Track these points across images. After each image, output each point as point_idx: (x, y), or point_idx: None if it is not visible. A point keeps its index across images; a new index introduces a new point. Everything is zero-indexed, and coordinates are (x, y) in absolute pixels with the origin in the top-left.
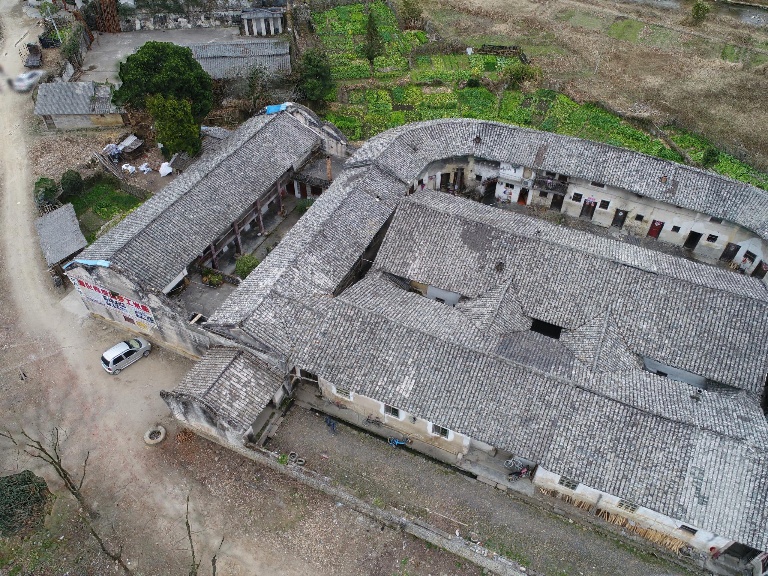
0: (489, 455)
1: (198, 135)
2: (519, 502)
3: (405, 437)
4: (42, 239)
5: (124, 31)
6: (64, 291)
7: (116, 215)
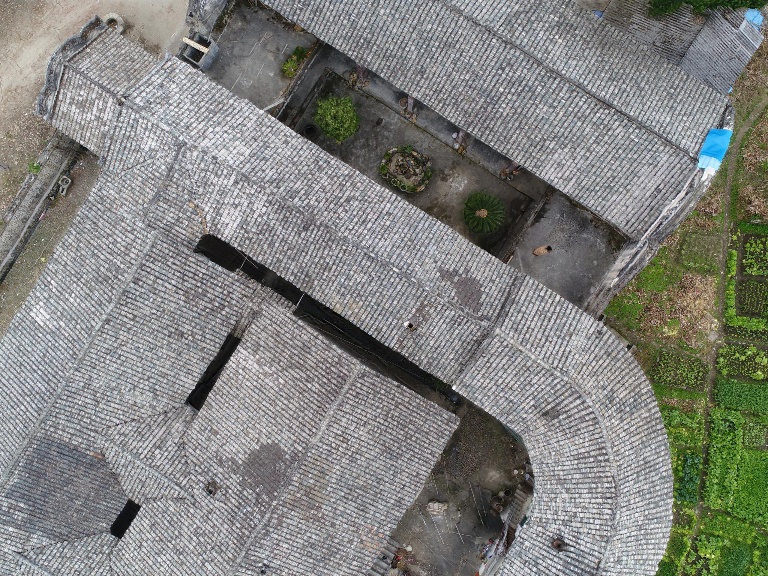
0: None
1: None
2: None
3: None
4: None
5: None
6: None
7: None
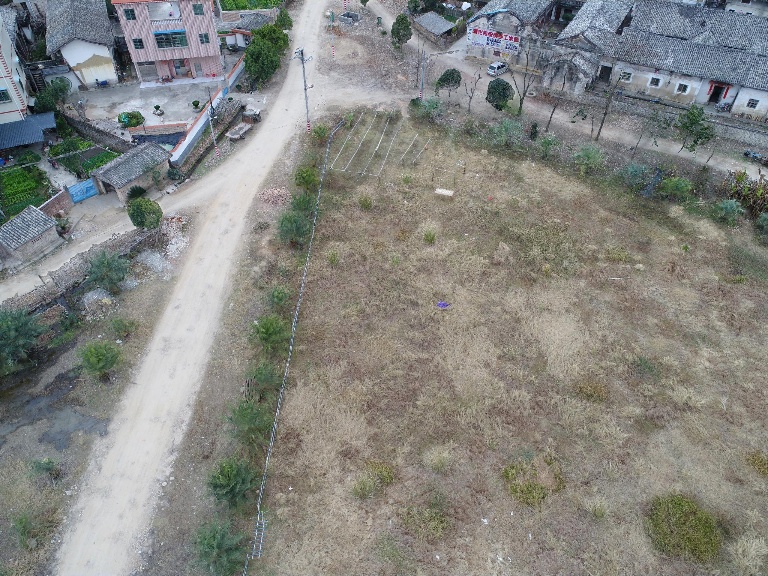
0: (705, 105)
1: None
2: (724, 120)
3: (660, 98)
4: (425, 26)
5: None
6: (444, 50)
7: (460, 17)
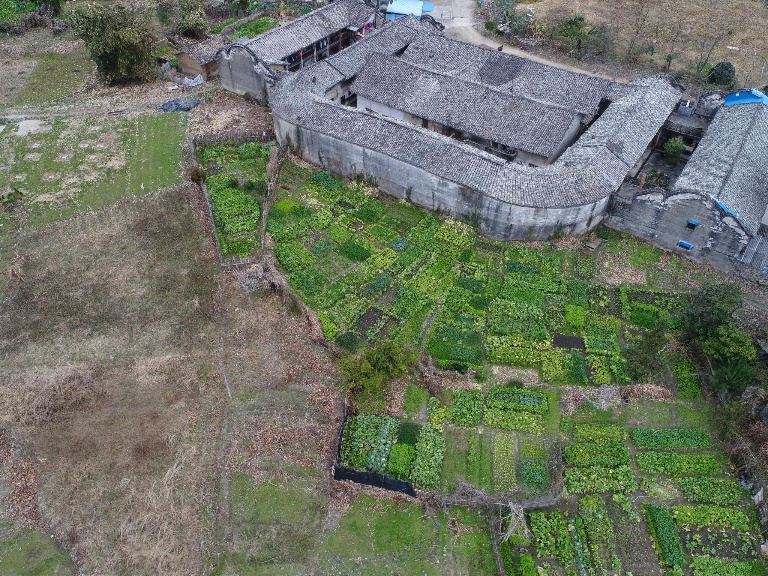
0: None
1: None
2: None
3: None
4: None
5: None
6: None
7: None
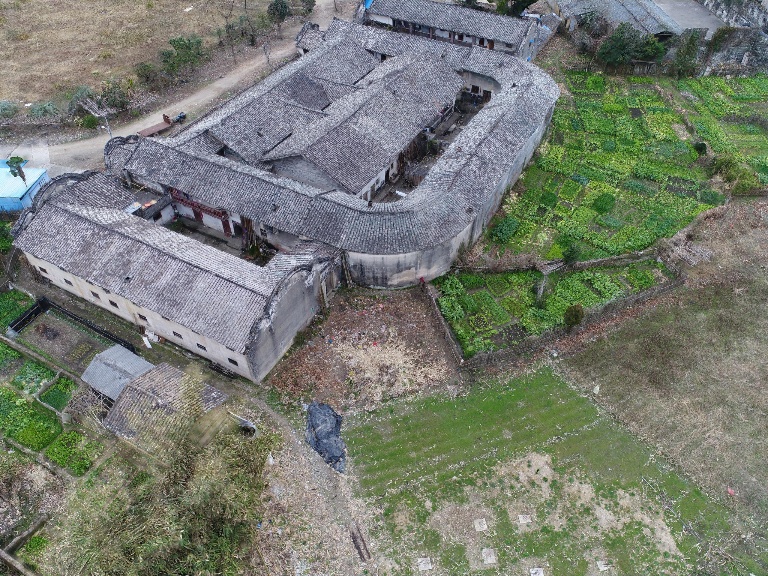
0: None
1: (499, 4)
2: None
3: None
4: None
5: (699, 2)
6: None
7: None
